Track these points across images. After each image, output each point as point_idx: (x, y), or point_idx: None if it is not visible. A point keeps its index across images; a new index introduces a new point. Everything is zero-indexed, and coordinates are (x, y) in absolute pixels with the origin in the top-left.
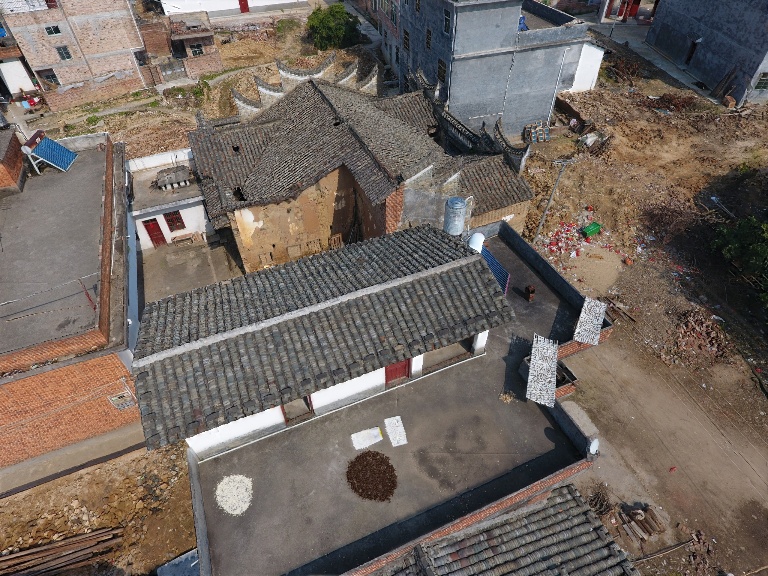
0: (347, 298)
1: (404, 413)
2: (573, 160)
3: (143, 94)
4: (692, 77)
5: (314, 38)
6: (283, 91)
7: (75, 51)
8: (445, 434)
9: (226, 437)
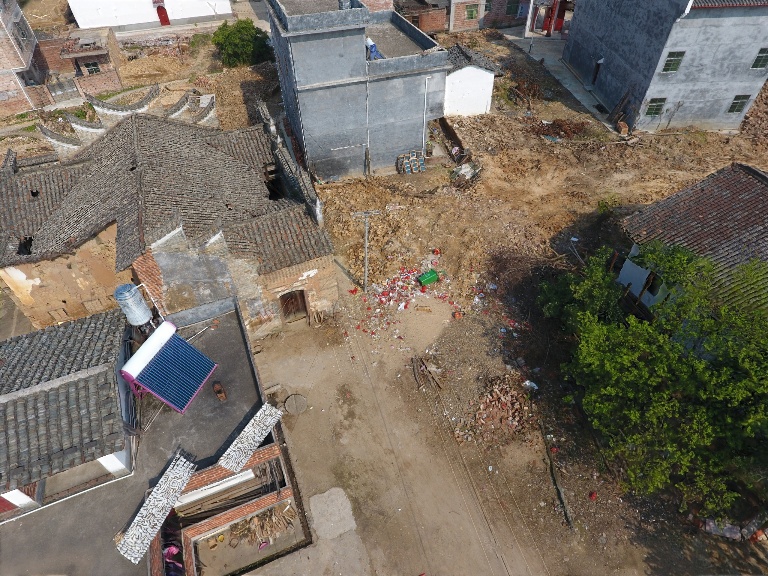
0: None
1: None
2: (435, 195)
3: (29, 116)
4: (596, 99)
5: (223, 54)
6: (104, 127)
7: None
8: None
9: None
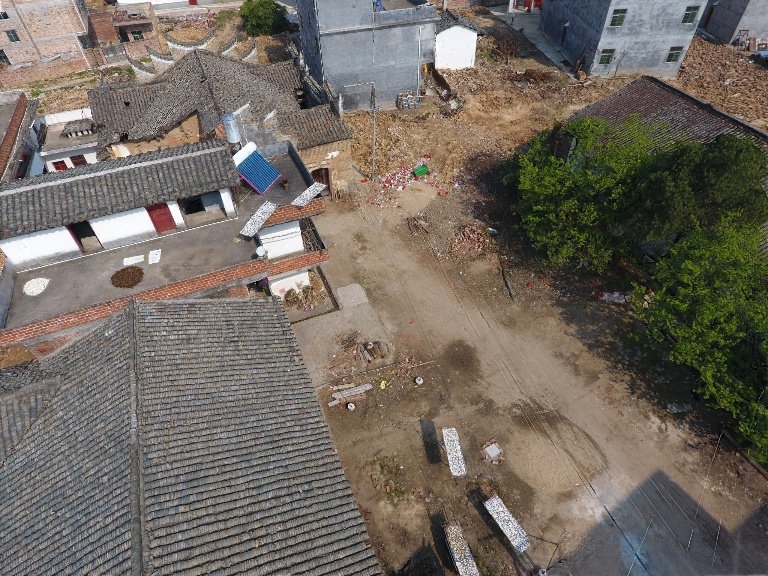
0: (123, 168)
1: (165, 248)
2: (427, 120)
3: (87, 74)
4: (563, 57)
5: (247, 26)
6: (173, 59)
7: (23, 34)
8: (186, 257)
9: (35, 255)
